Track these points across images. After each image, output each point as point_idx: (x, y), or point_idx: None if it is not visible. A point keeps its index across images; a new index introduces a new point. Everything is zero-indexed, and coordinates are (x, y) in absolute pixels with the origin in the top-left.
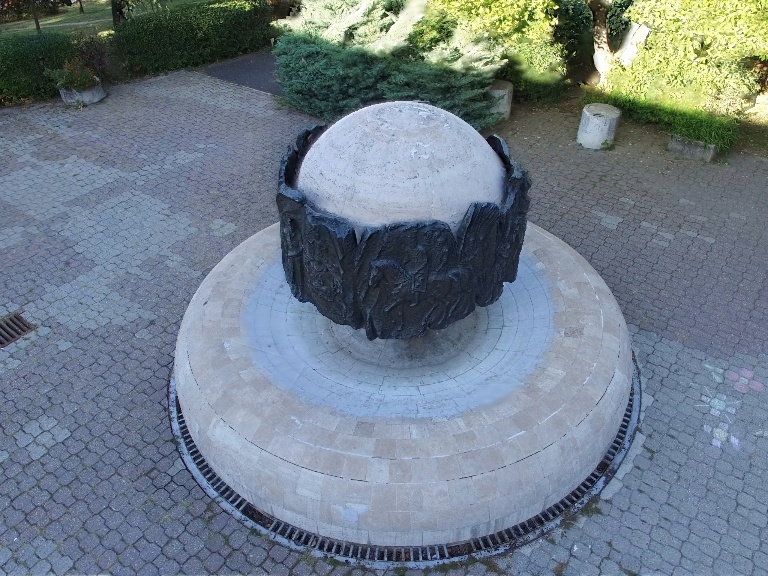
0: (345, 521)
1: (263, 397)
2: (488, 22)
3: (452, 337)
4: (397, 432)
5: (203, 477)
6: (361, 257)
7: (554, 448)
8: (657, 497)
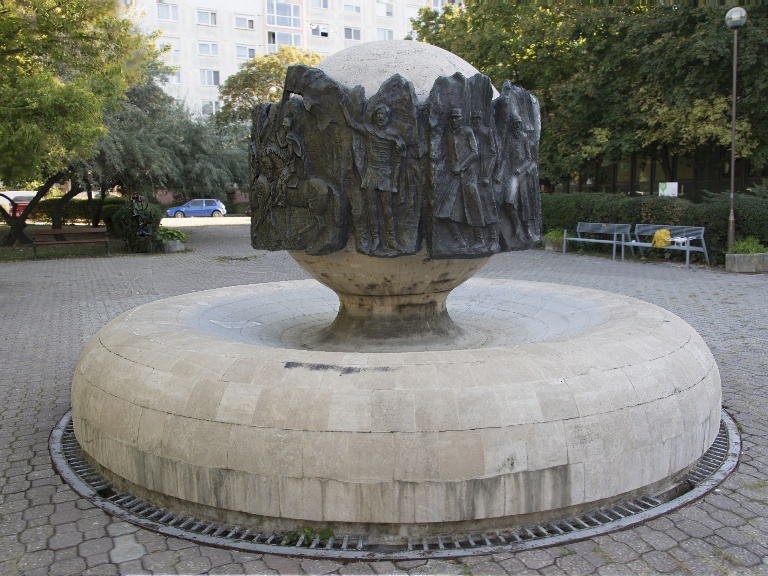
0: None
1: None
2: None
3: None
4: (476, 280)
5: None
6: None
7: None
8: None
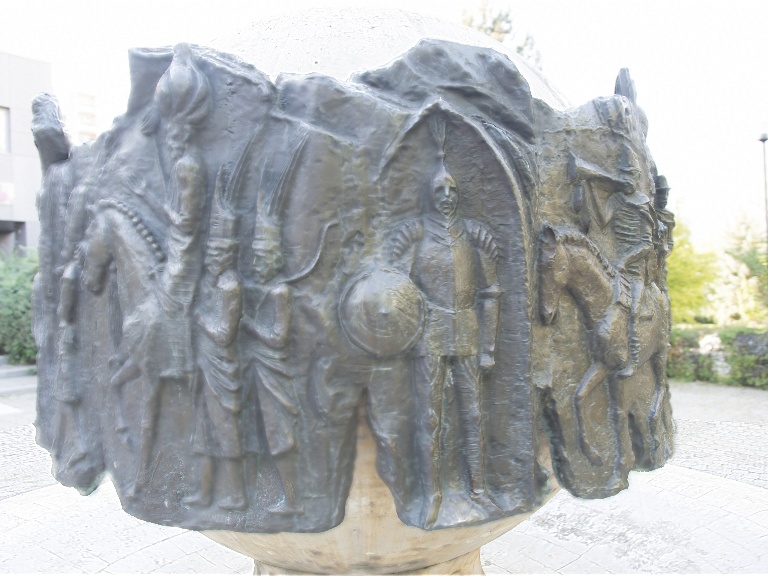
0: None
1: None
2: None
3: None
4: None
5: None
6: None
7: None
8: None
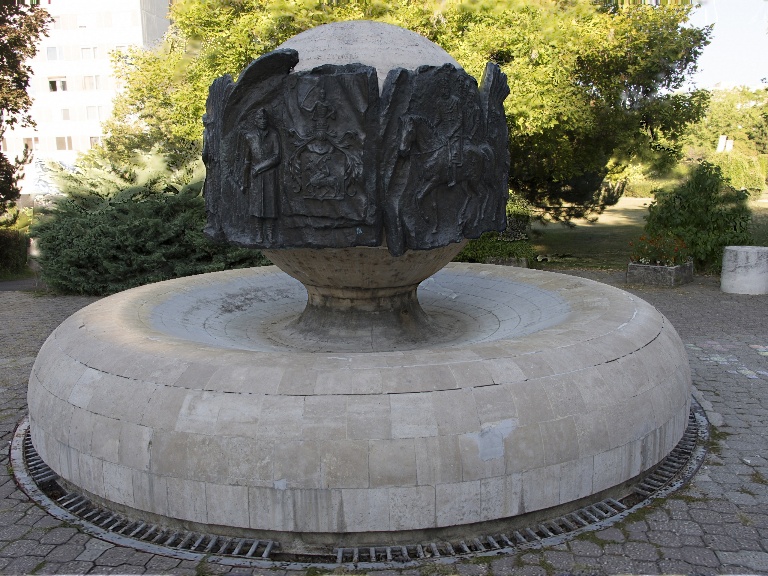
0: (485, 462)
1: (262, 355)
2: None
3: (443, 326)
4: None
5: (159, 546)
6: (389, 108)
7: (665, 337)
8: (761, 413)
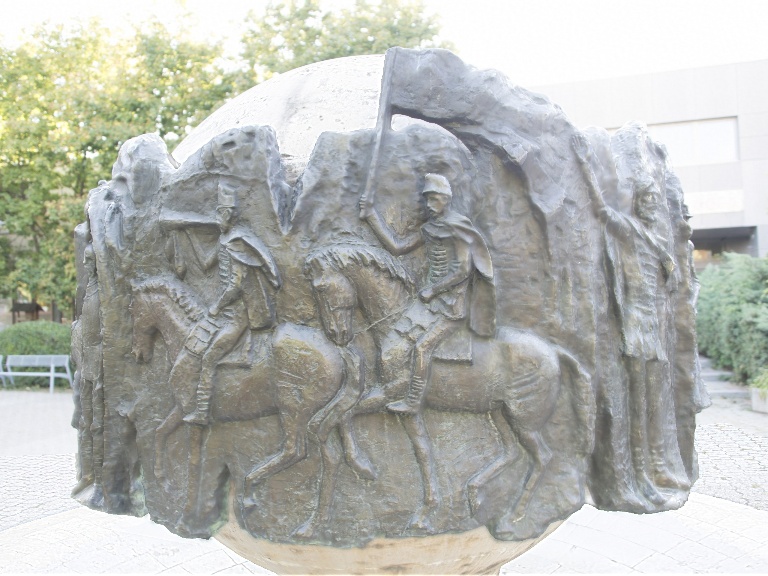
0: None
1: None
2: None
3: None
4: None
5: None
6: None
7: None
8: None
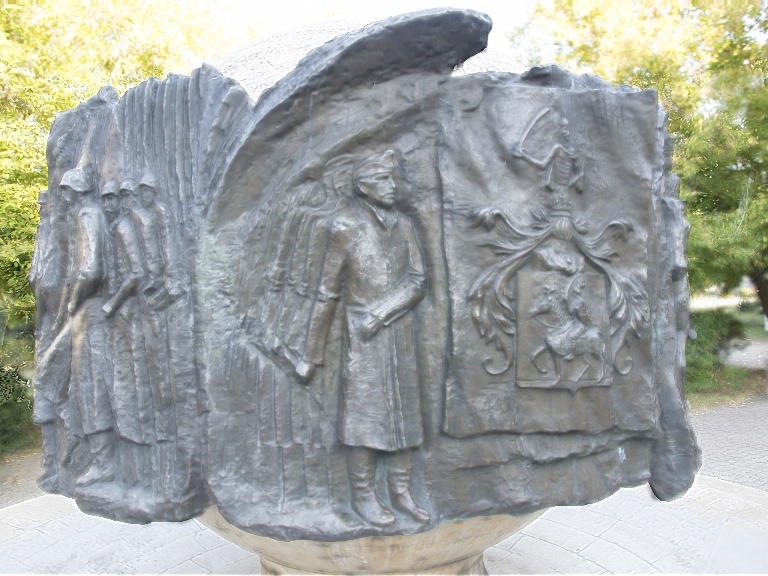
0: None
1: None
2: (8, 256)
3: None
4: None
5: None
6: (661, 178)
7: None
8: None
